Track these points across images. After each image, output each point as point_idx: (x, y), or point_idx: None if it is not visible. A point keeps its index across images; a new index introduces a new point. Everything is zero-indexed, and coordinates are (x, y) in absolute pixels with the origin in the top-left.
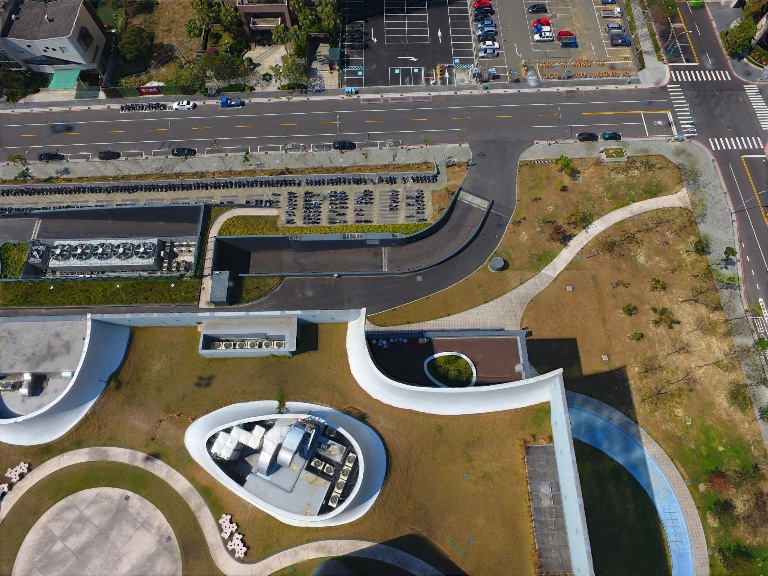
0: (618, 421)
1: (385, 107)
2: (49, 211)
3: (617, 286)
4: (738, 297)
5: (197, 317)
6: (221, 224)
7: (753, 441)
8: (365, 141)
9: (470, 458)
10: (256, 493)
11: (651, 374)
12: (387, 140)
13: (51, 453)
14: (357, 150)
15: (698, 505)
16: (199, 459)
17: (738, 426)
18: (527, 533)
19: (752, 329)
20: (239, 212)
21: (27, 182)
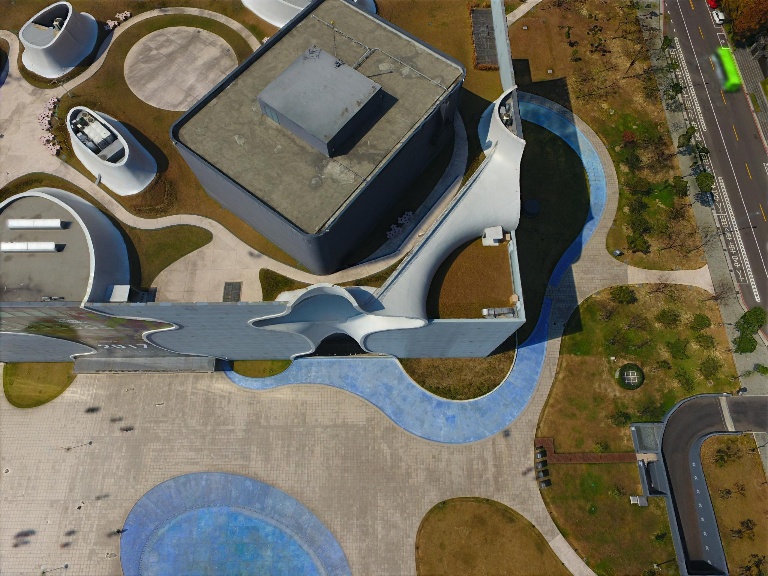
0: (557, 110)
1: None
2: None
3: (563, 28)
4: (658, 36)
5: None
6: None
7: (660, 123)
8: None
9: (433, 15)
10: (289, 2)
11: (585, 82)
12: None
13: (145, 8)
14: None
15: (614, 160)
16: (249, 2)
17: (649, 114)
18: (470, 50)
19: (667, 56)
20: None
21: None
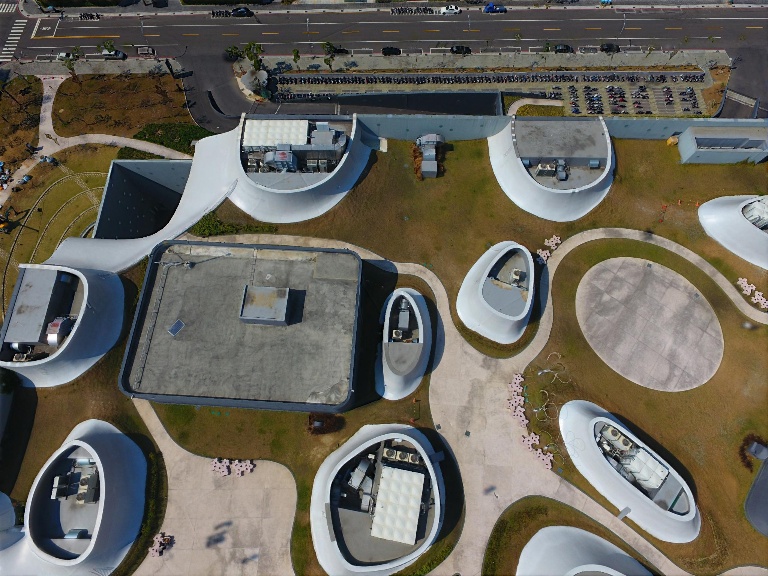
0: None
1: (640, 17)
2: (355, 95)
3: None
4: None
5: (690, 122)
6: (515, 111)
7: None
8: (628, 45)
9: None
10: None
11: None
12: (648, 45)
13: (574, 230)
14: (622, 53)
15: None
16: (718, 232)
17: None
18: None
19: None
20: (528, 102)
21: (320, 72)
